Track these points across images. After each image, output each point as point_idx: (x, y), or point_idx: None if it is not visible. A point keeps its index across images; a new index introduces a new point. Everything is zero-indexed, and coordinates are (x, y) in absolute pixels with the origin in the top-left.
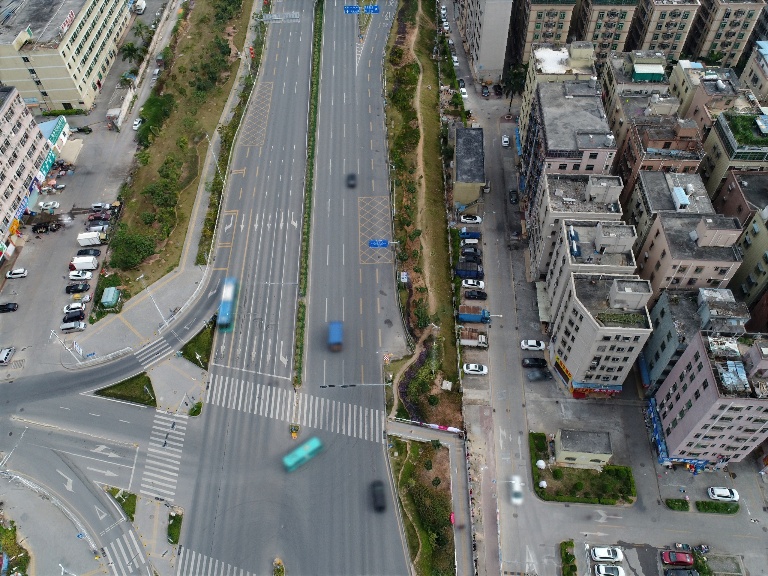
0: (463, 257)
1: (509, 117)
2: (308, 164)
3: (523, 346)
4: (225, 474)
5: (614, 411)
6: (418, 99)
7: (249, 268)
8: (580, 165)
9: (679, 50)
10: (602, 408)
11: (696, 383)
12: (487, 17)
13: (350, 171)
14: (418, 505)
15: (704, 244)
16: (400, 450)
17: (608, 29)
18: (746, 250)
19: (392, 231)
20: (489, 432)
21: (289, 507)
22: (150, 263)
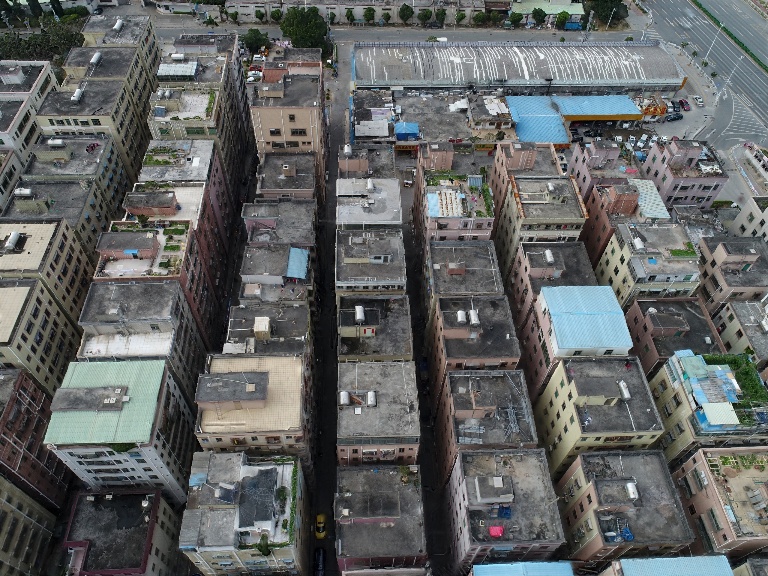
0: None
1: None
2: None
3: None
4: None
5: None
6: None
7: None
8: None
9: None
10: None
11: None
12: None
13: None
14: None
15: None
16: None
17: None
18: None
19: None
20: None
21: None
22: None
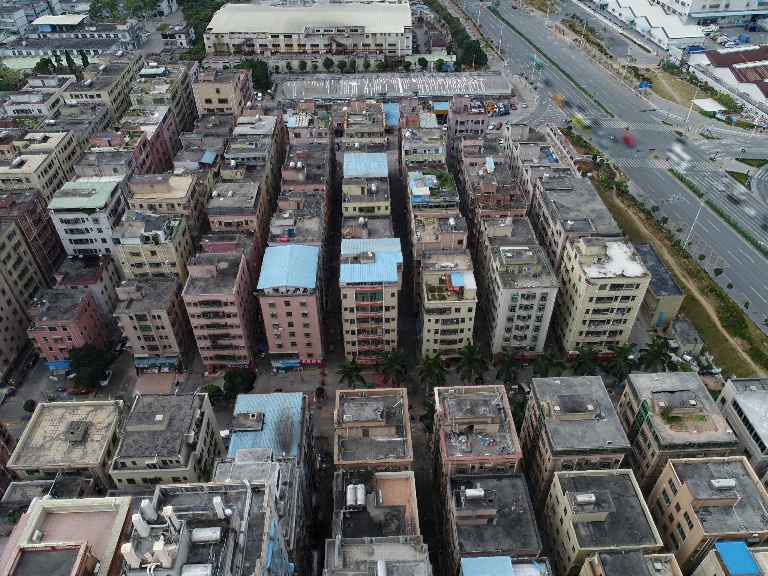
0: None
1: None
2: None
3: None
4: (675, 146)
5: None
6: None
7: (761, 215)
8: None
9: None
10: None
11: None
12: None
13: (761, 288)
14: None
15: None
16: None
17: None
18: None
19: None
20: None
21: (637, 141)
22: None
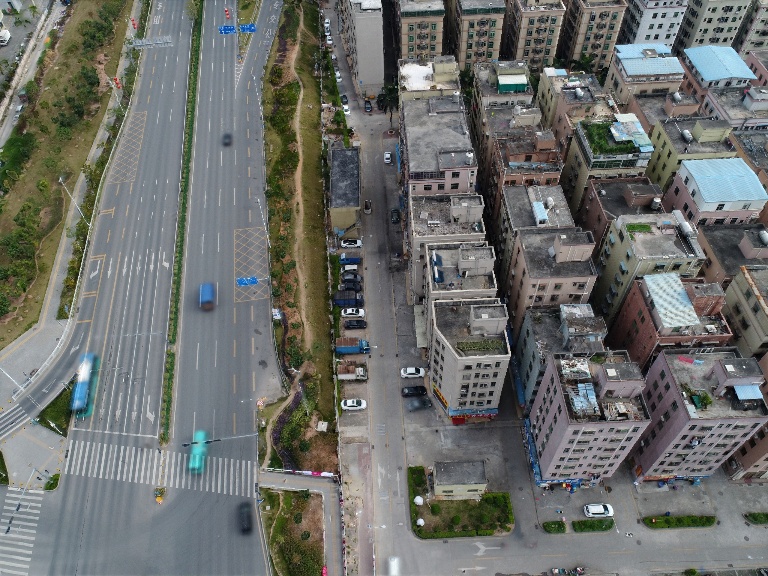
0: (343, 285)
1: (392, 132)
2: (180, 198)
3: (402, 375)
4: (83, 552)
5: (493, 434)
6: (298, 120)
7: (115, 318)
8: (445, 185)
9: (553, 54)
10: (481, 432)
11: (554, 407)
12: (359, 32)
13: (226, 202)
14: (289, 562)
15: (562, 260)
16: (272, 503)
17: (481, 38)
18: (607, 260)
19: (268, 264)
20: (367, 471)
21: None
22: (5, 322)
